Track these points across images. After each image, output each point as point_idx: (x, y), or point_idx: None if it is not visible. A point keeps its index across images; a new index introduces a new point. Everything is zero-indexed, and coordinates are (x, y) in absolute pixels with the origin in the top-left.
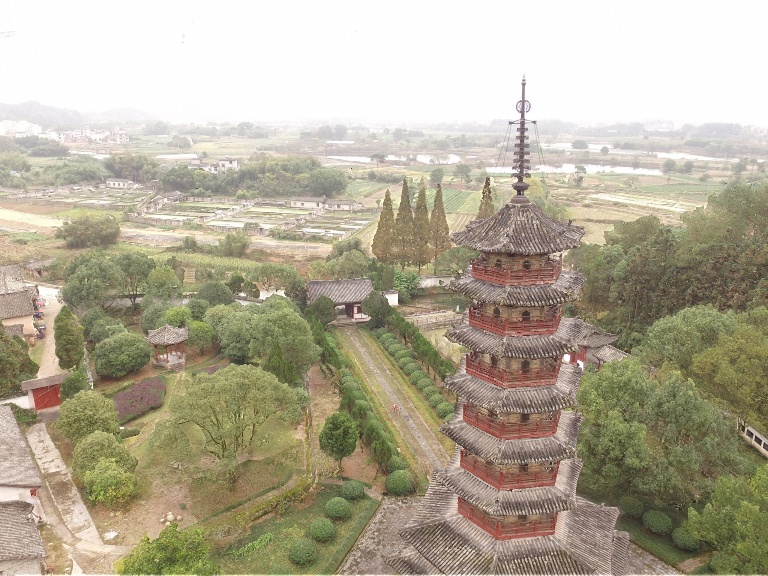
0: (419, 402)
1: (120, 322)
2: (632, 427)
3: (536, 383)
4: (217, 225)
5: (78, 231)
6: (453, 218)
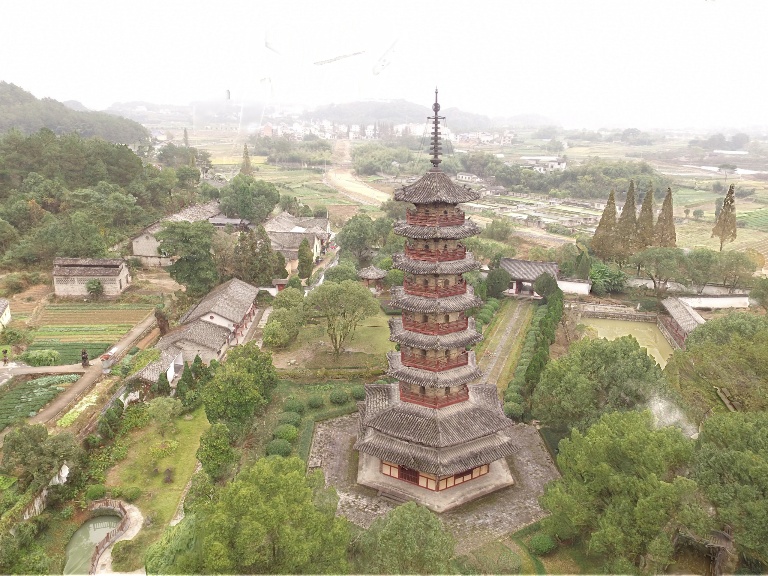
0: (514, 356)
1: (356, 261)
2: (577, 379)
3: (425, 294)
4: (511, 216)
5: (394, 206)
6: (765, 237)
